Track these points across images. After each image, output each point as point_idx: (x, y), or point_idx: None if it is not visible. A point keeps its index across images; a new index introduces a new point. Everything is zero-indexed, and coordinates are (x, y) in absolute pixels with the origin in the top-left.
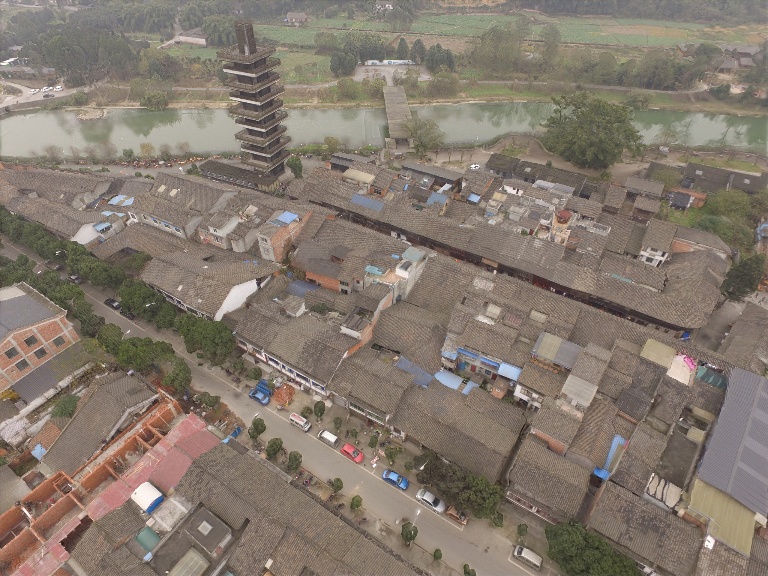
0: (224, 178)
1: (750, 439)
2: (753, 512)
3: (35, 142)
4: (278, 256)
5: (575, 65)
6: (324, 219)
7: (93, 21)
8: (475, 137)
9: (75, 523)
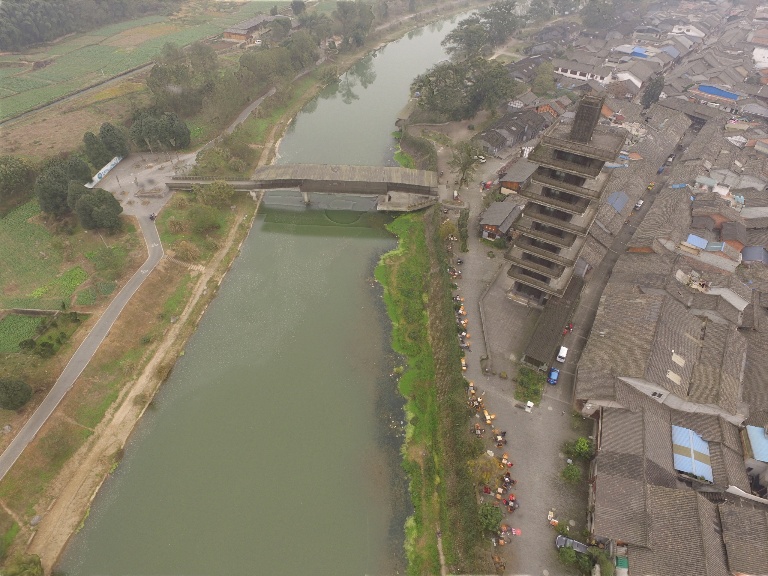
0: None
1: None
2: None
3: None
4: None
5: (273, 69)
6: None
7: None
8: (379, 157)
9: None
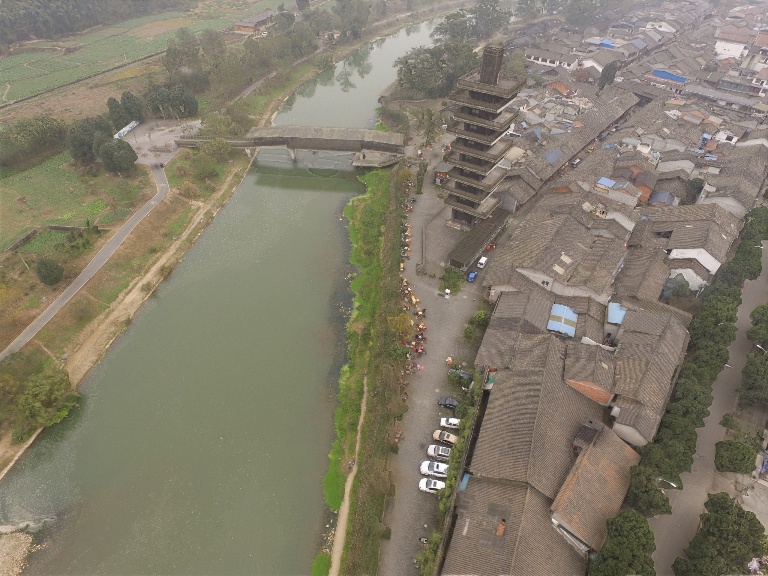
0: (483, 248)
1: (726, 94)
2: (759, 102)
3: None
4: None
5: (274, 54)
6: None
7: None
8: (360, 127)
9: None
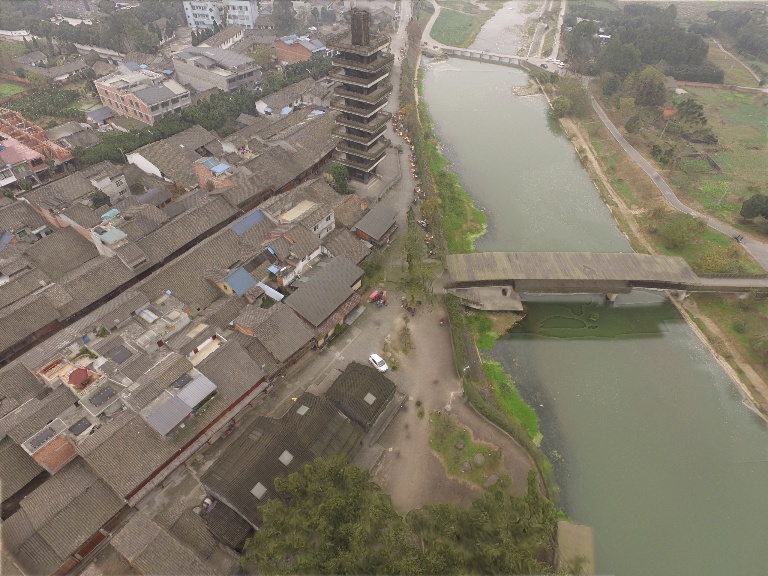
0: None
1: None
2: None
3: (460, 82)
4: (203, 185)
5: None
6: (220, 192)
7: (754, 38)
8: (566, 414)
9: (7, 137)
